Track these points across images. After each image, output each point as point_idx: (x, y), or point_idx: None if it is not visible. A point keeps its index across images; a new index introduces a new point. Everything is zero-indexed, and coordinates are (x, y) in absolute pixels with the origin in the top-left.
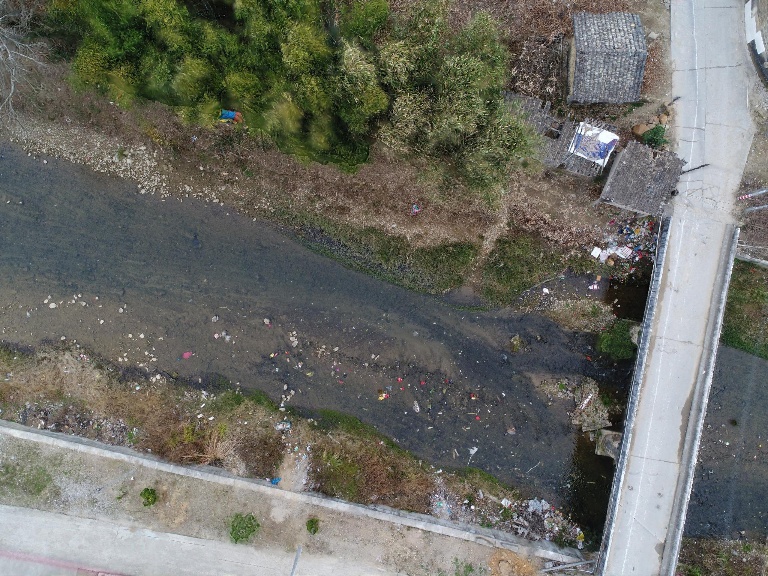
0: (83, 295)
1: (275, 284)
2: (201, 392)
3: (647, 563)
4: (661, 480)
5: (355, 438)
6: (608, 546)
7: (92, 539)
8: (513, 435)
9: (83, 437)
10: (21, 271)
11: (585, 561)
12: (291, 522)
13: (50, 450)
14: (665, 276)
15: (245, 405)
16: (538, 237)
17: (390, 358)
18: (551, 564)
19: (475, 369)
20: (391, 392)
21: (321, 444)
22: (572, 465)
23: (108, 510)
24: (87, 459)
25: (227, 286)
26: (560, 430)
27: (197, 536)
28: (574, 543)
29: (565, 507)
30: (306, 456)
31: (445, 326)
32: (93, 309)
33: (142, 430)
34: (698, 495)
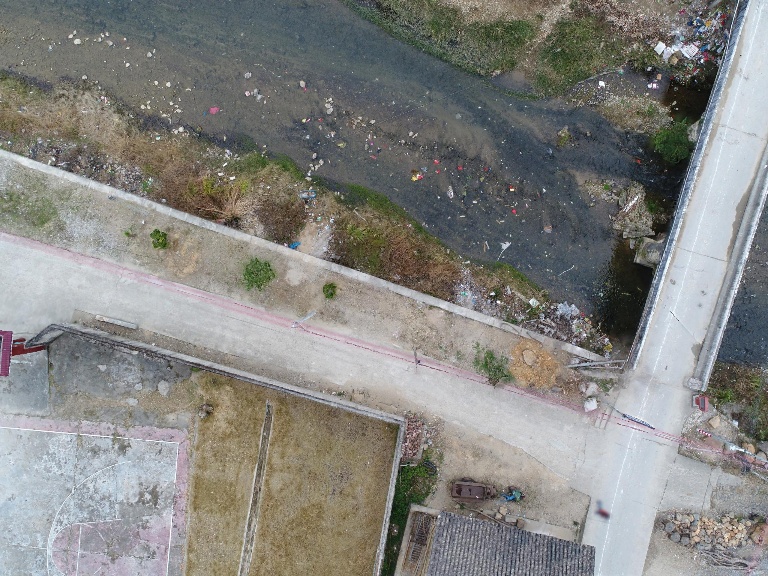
0: (111, 35)
1: (316, 47)
2: (224, 151)
3: (681, 363)
4: (706, 277)
5: (382, 217)
6: (644, 335)
7: (93, 280)
8: (549, 234)
9: (95, 180)
10: (48, 2)
11: (614, 360)
12: (307, 287)
13: (59, 183)
14: (736, 61)
15: (270, 168)
16: (601, 21)
17: (429, 138)
18: (577, 360)
19: (517, 160)
20: (426, 174)
21: (346, 217)
22: (608, 273)
23: (114, 251)
24: (97, 197)
25: (264, 43)
26: (599, 234)
27: (205, 289)
28: (601, 352)
29: (595, 316)
30: (329, 227)
31: (490, 112)
32: (120, 50)
33: (158, 181)
34: (737, 318)
